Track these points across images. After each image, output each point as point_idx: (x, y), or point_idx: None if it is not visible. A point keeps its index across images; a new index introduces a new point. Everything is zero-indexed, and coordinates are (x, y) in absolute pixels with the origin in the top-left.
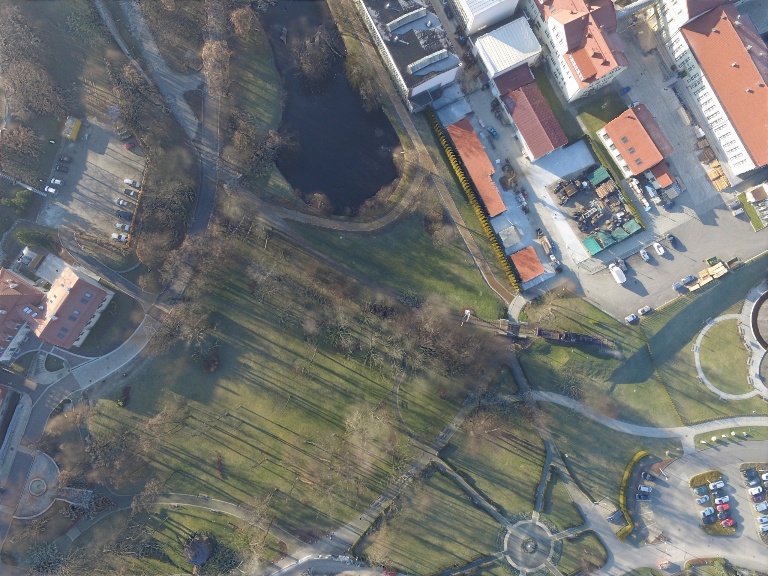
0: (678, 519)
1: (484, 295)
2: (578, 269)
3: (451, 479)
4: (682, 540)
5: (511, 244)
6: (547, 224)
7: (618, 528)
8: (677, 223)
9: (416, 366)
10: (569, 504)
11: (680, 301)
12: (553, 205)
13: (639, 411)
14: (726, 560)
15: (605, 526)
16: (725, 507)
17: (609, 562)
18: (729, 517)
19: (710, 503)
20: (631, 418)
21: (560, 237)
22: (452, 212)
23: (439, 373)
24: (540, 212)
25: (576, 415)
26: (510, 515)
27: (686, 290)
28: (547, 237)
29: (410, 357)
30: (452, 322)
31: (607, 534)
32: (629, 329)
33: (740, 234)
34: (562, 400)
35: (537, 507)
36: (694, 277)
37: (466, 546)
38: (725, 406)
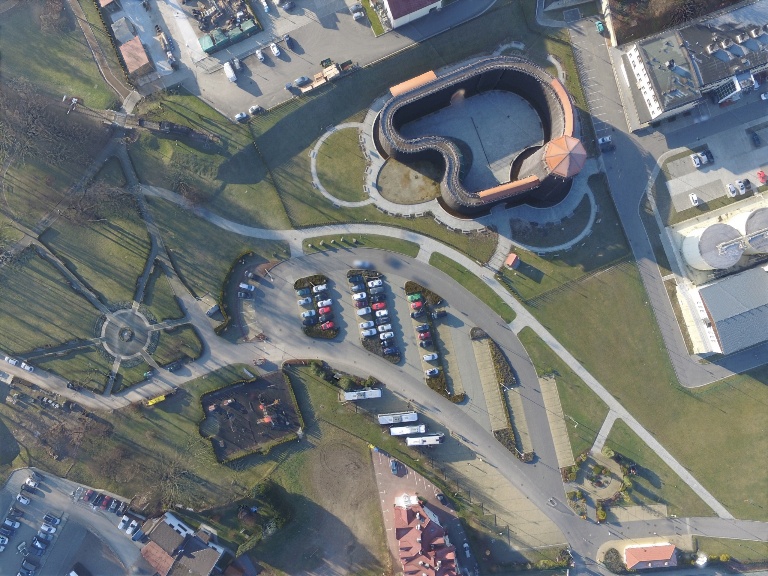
0: (280, 320)
1: (99, 88)
2: (196, 68)
3: (50, 263)
4: (282, 340)
5: (121, 35)
6: (168, 22)
7: (218, 324)
8: (297, 25)
9: (24, 152)
10: (171, 297)
11: (292, 102)
12: (176, 3)
13: (249, 212)
14: (325, 363)
15: (205, 321)
16: (325, 309)
17: (205, 355)
18: (330, 320)
19: (313, 306)
20: (241, 218)
21: (180, 35)
22: (73, 5)
23: (47, 160)
24: (162, 10)
25: (185, 212)
26: (110, 303)
27: (300, 92)
28: (166, 34)
29: (19, 143)
30: (58, 109)
31: (206, 329)
32: (238, 127)
33: (360, 39)
34: (172, 196)
35: (138, 298)
36: (308, 79)
37: (62, 329)
38: (337, 212)
